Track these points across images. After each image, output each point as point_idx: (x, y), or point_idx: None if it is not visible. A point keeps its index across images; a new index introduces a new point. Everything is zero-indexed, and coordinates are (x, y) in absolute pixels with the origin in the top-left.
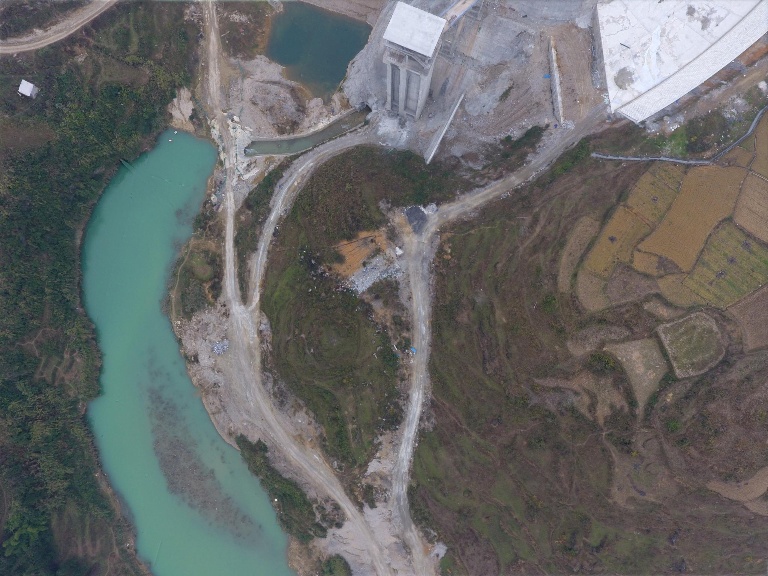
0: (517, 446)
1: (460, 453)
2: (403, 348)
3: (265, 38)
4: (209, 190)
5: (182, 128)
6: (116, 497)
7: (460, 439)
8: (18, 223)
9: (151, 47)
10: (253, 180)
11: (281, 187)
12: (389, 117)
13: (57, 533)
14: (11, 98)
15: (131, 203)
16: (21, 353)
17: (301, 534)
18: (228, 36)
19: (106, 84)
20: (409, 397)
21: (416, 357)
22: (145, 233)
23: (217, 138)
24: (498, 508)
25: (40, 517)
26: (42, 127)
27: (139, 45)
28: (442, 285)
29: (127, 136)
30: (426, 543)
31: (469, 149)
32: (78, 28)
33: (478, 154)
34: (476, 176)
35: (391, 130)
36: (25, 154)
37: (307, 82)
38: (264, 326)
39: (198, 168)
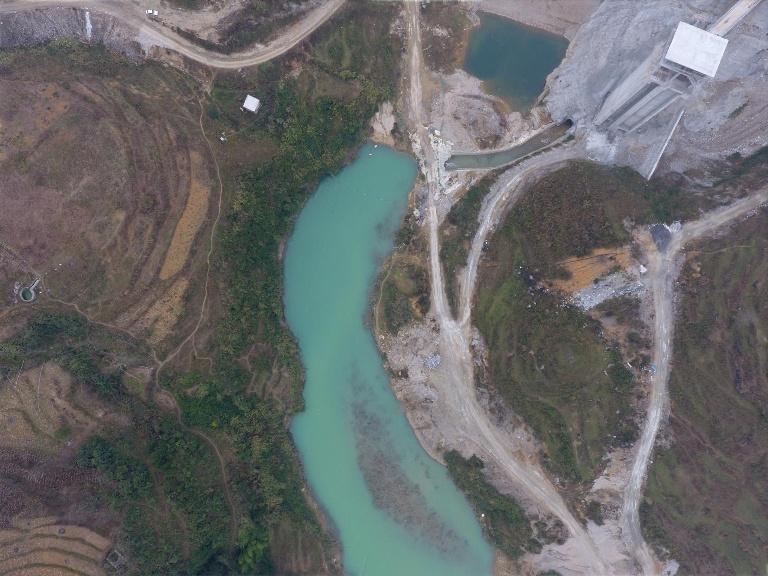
0: (767, 465)
1: (700, 471)
2: (640, 366)
3: (463, 52)
4: (411, 204)
5: (382, 142)
6: (322, 512)
7: (702, 457)
8: (243, 239)
9: (361, 61)
10: (455, 194)
11: (489, 202)
12: (597, 132)
13: (274, 549)
14: (234, 113)
15: (330, 217)
16: (238, 368)
17: (513, 550)
18: (431, 50)
19: (320, 99)
20: (647, 415)
21: (656, 375)
22: (344, 247)
23: (418, 152)
24: (738, 526)
25: (264, 533)
26: (266, 142)
27: (352, 60)
28: (691, 303)
29: (335, 150)
30: (657, 560)
31: (690, 165)
32: (297, 43)
33: (702, 170)
34: (713, 193)
35: (599, 145)
36: (253, 170)
37: (505, 96)
38: (477, 341)
39: (397, 182)
